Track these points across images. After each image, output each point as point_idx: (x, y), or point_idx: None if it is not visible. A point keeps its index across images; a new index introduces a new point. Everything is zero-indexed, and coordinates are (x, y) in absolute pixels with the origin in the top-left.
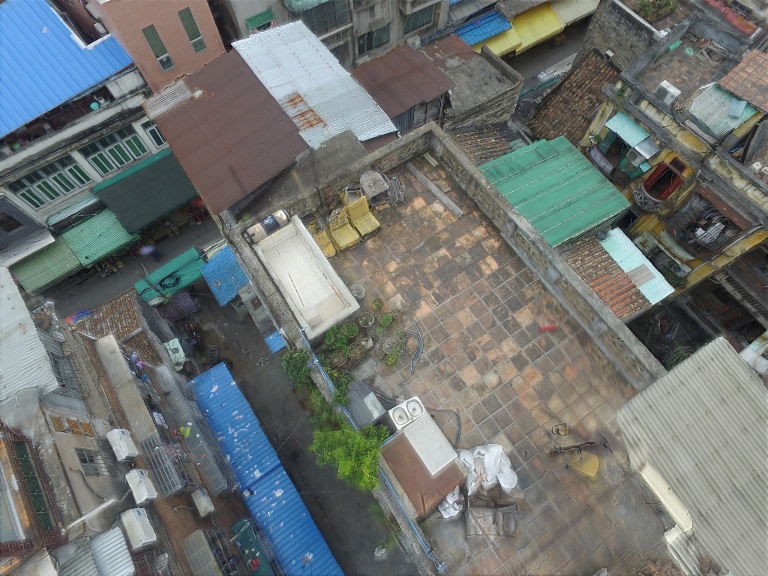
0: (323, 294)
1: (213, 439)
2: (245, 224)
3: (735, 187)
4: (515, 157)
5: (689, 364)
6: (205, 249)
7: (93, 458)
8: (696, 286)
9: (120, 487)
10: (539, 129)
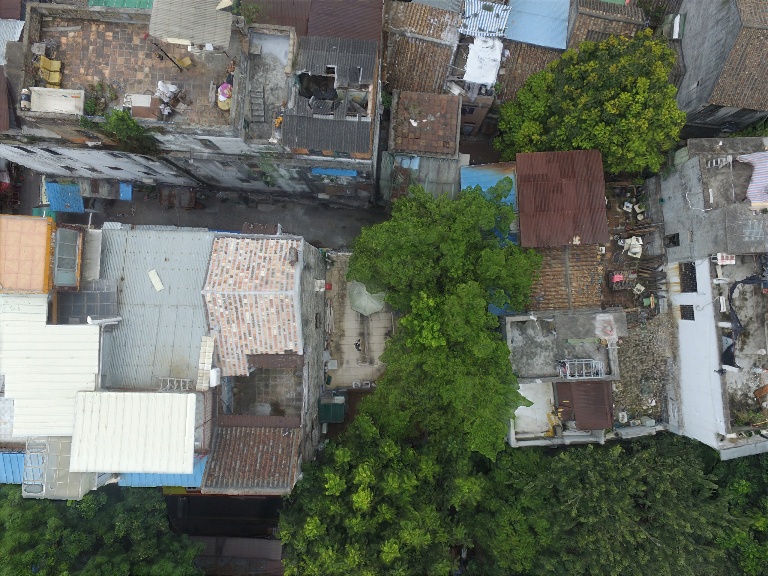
0: (73, 103)
1: None
2: (18, 107)
3: None
4: None
5: (154, 3)
6: (40, 203)
7: None
8: None
9: None
10: None
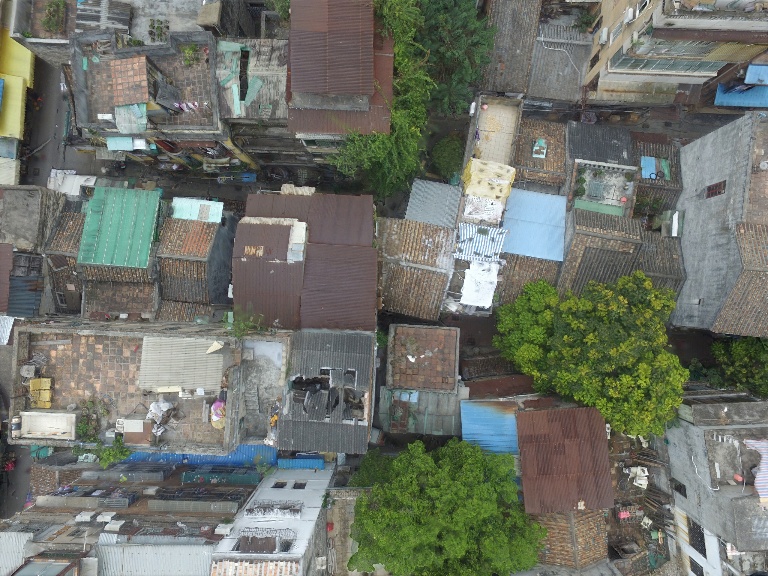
0: (64, 419)
1: (142, 466)
2: (9, 435)
3: (188, 133)
4: (88, 228)
5: (143, 354)
6: None
7: (78, 531)
8: (254, 156)
9: (99, 525)
10: (100, 142)
